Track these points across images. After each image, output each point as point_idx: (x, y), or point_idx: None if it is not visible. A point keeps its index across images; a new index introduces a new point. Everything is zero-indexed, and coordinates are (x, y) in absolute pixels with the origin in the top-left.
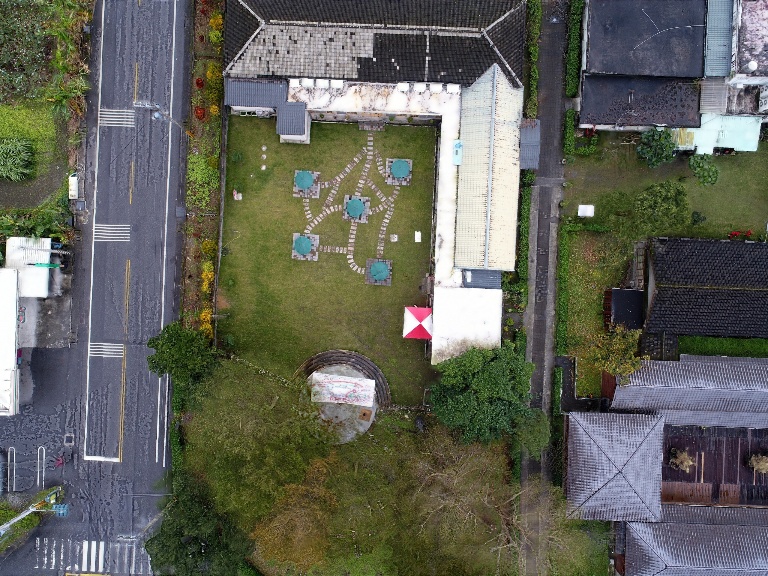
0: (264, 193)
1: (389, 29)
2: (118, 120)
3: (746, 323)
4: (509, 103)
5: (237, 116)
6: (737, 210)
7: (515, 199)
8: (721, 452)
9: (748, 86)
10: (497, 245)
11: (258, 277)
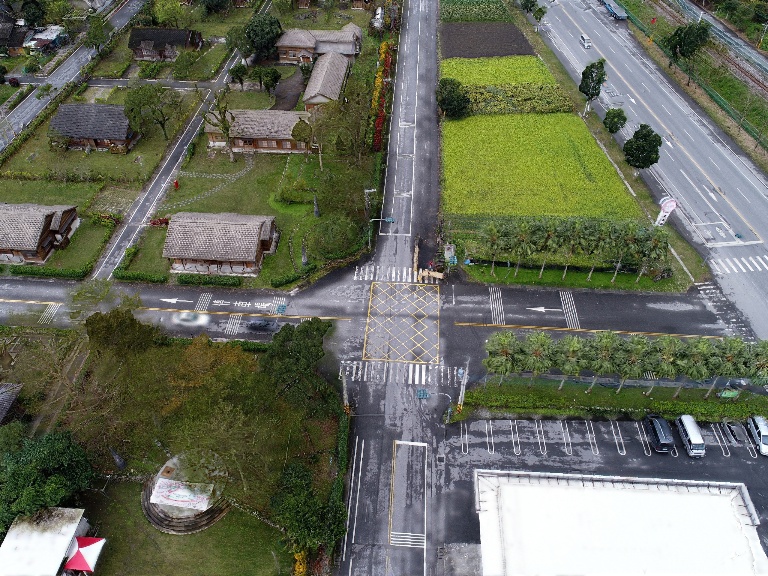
0: None
1: None
2: None
3: None
4: None
5: None
6: None
7: None
8: None
9: None
10: None
11: None
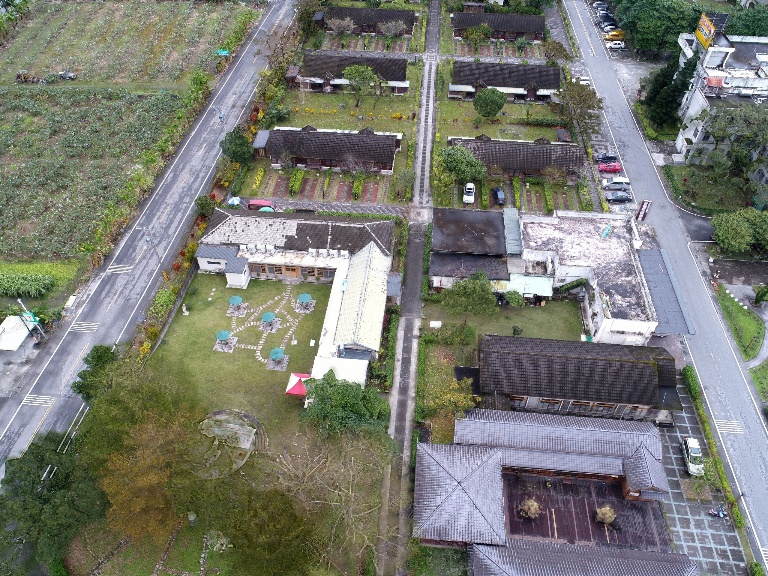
0: (205, 312)
1: (307, 221)
2: (120, 270)
3: (559, 385)
4: (381, 262)
5: (201, 273)
6: (552, 337)
7: (382, 310)
8: (570, 510)
9: (538, 262)
10: (365, 331)
11: (183, 359)
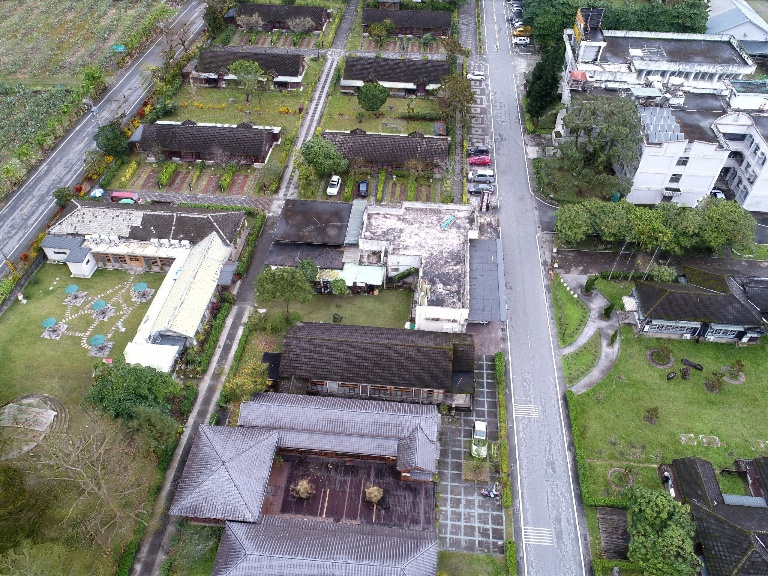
0: (43, 301)
1: (153, 212)
2: None
3: (356, 370)
4: (219, 251)
5: (50, 263)
6: (377, 325)
7: (208, 298)
8: (345, 490)
9: (375, 251)
10: (183, 318)
11: (8, 346)
